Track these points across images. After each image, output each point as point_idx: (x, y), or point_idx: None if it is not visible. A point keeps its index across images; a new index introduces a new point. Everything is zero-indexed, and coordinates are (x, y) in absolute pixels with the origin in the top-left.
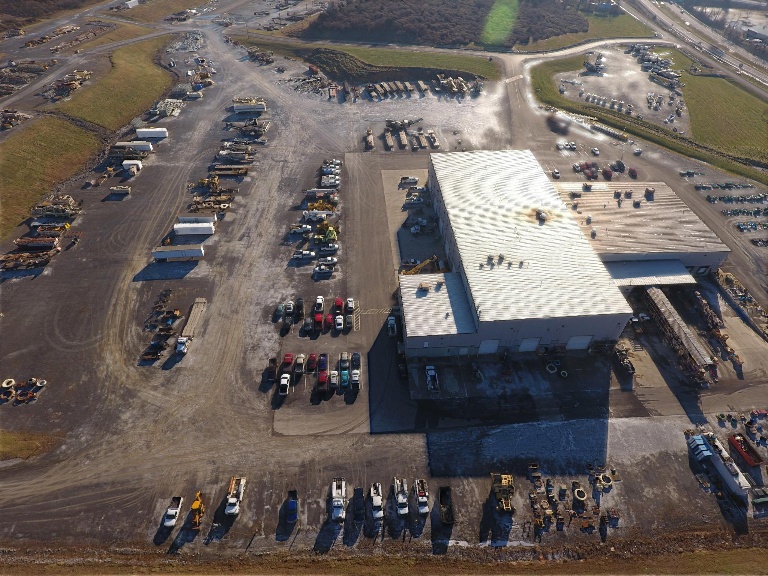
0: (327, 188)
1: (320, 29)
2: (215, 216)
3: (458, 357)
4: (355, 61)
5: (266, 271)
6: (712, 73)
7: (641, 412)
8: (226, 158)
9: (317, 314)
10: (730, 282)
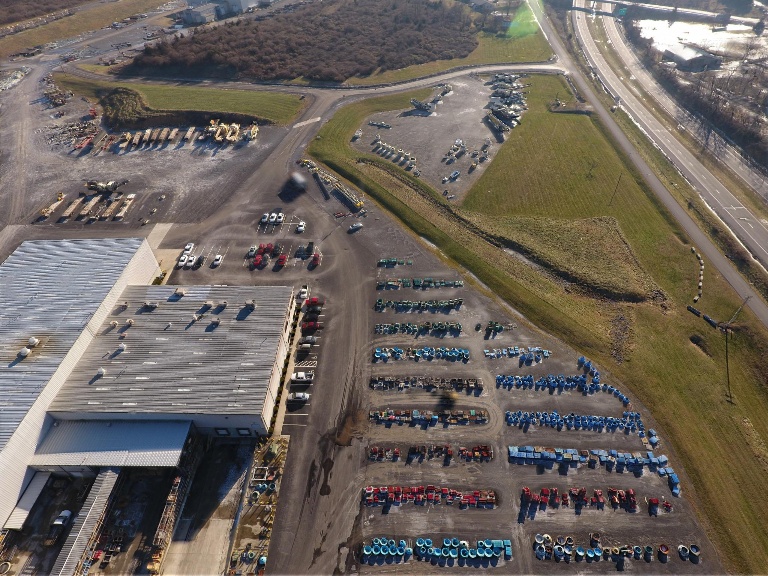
0: None
1: (139, 65)
2: None
3: None
4: (137, 104)
5: None
6: (576, 109)
7: None
8: None
9: None
10: (271, 454)
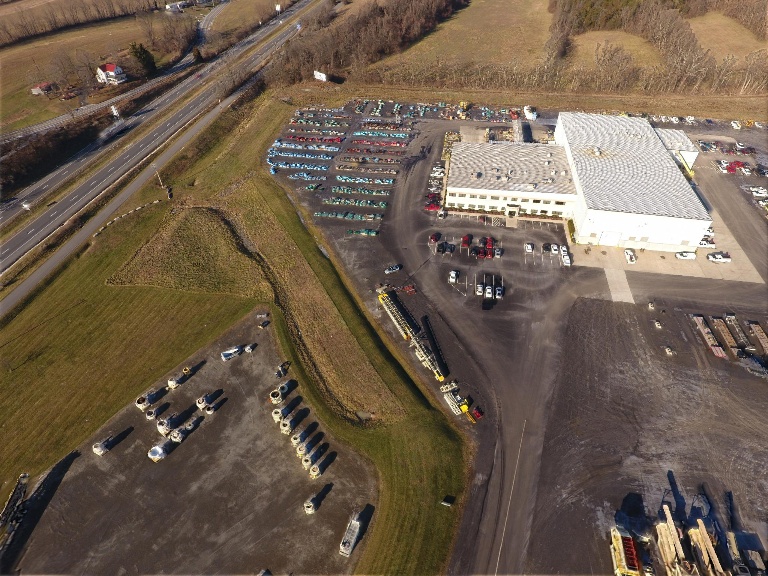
0: None
1: None
2: None
3: None
4: None
5: None
6: None
7: (551, 126)
8: None
9: None
10: None
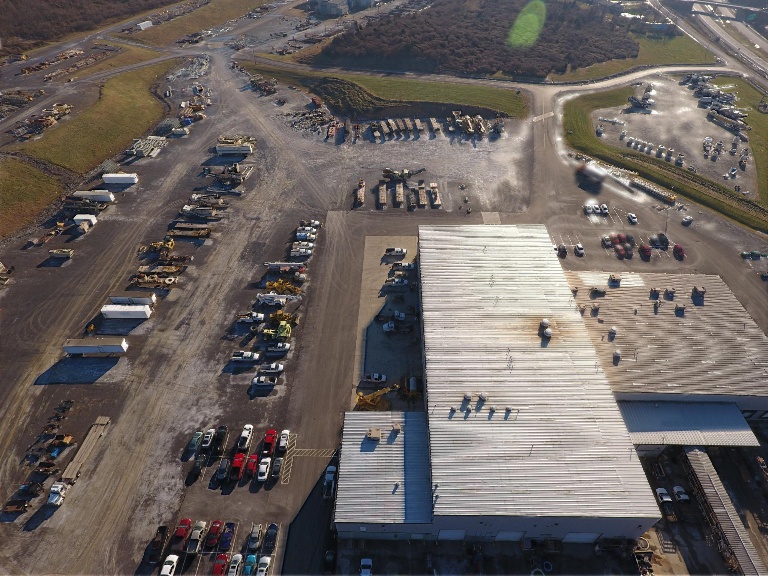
0: (297, 259)
1: (332, 55)
2: (153, 296)
3: (409, 543)
4: (363, 93)
5: (195, 378)
6: None
7: None
8: (191, 214)
9: (238, 454)
10: None
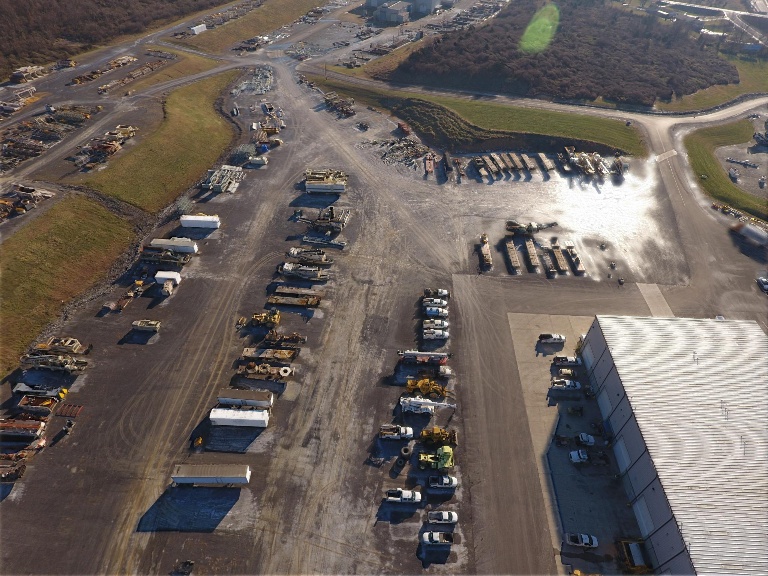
0: (431, 343)
1: (412, 72)
2: (271, 398)
3: None
4: (457, 121)
5: (343, 527)
6: None
7: None
8: (292, 274)
9: None
10: None
